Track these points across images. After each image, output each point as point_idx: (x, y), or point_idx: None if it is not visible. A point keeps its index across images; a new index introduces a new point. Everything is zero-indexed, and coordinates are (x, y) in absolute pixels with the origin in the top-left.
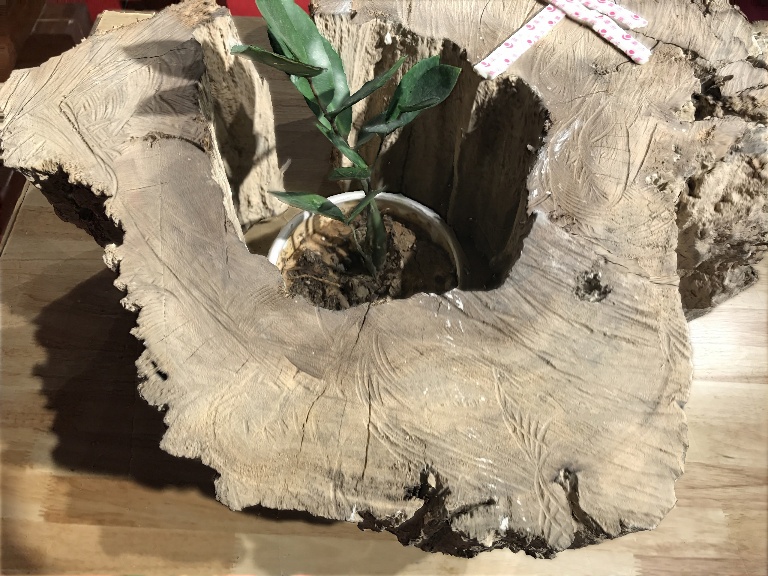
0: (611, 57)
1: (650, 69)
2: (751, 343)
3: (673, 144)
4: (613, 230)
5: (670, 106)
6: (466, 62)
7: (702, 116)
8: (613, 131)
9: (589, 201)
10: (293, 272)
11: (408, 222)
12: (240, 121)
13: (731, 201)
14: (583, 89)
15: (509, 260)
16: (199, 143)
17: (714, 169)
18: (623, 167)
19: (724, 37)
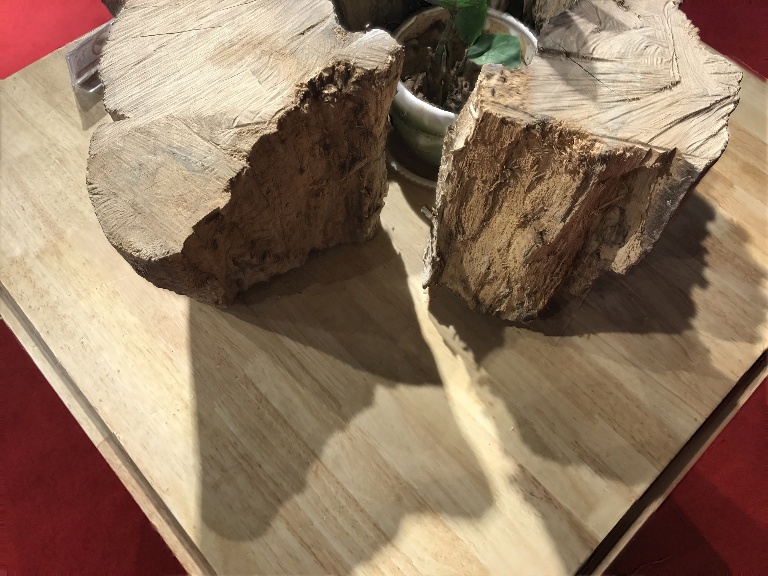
0: None
1: None
2: None
3: None
4: None
5: None
6: None
7: None
8: None
9: None
10: None
11: None
12: None
13: None
14: None
15: None
16: None
17: None
18: None
19: None
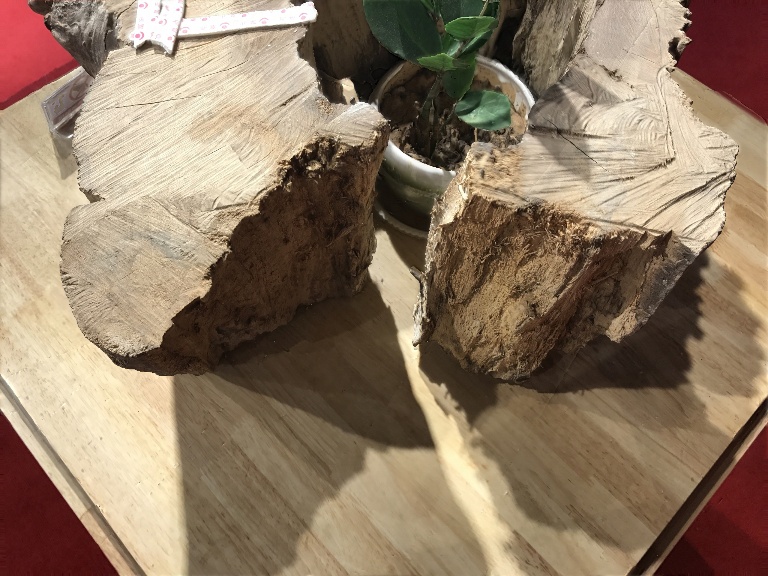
0: None
1: None
2: None
3: None
4: None
5: None
6: None
7: None
8: None
9: None
10: None
11: None
12: None
13: None
14: None
15: None
16: None
17: None
18: None
19: None
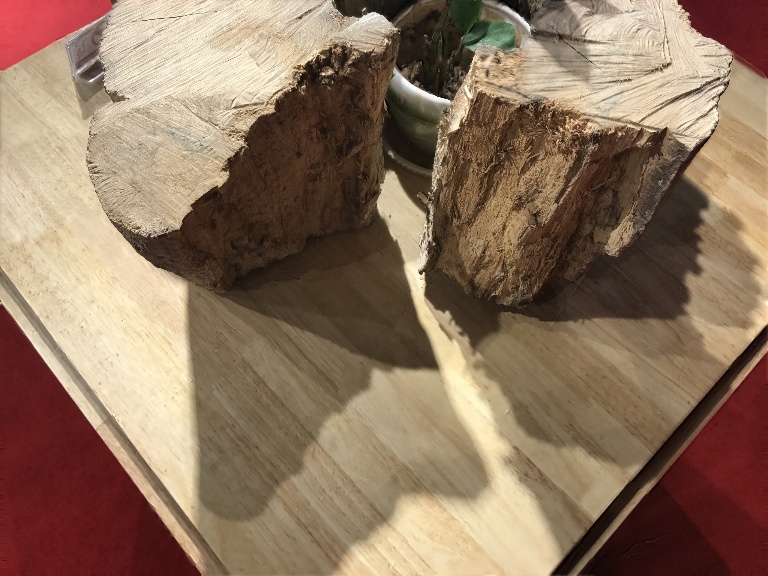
0: None
1: None
2: None
3: None
4: None
5: None
6: None
7: None
8: None
9: None
10: None
11: None
12: None
13: None
14: None
15: None
16: None
17: None
18: None
19: None
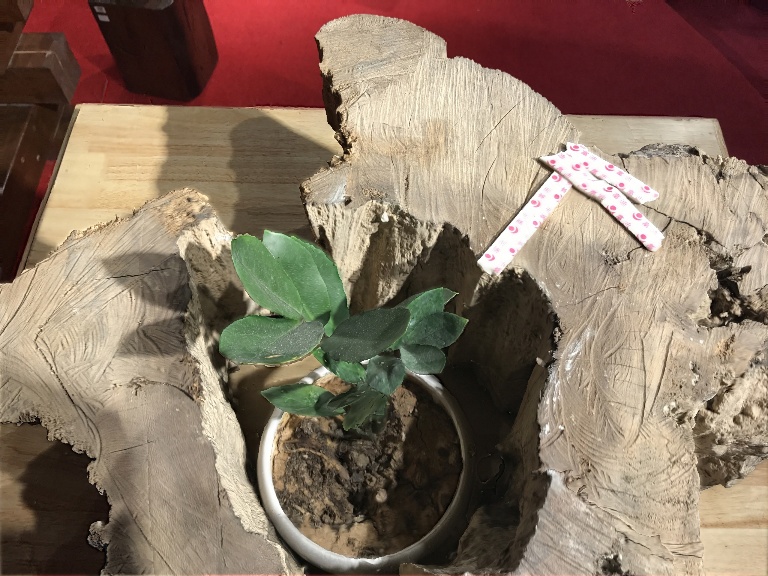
0: (622, 241)
1: (663, 257)
2: (762, 482)
3: (691, 361)
4: (631, 479)
5: (686, 308)
6: (469, 249)
7: (718, 308)
8: (627, 342)
9: (604, 439)
10: (290, 445)
11: (408, 381)
12: (229, 295)
13: (751, 416)
14: (593, 285)
15: (517, 452)
16: (187, 391)
17: (734, 386)
18: (639, 392)
19: (740, 212)
